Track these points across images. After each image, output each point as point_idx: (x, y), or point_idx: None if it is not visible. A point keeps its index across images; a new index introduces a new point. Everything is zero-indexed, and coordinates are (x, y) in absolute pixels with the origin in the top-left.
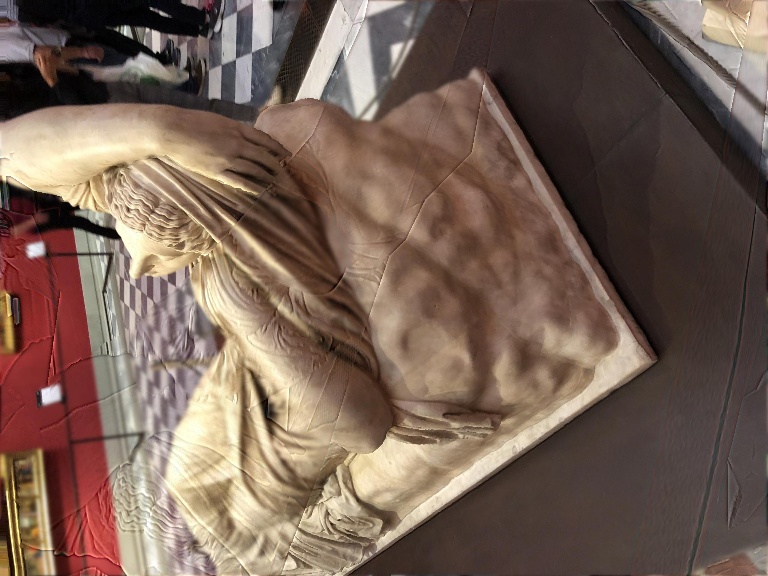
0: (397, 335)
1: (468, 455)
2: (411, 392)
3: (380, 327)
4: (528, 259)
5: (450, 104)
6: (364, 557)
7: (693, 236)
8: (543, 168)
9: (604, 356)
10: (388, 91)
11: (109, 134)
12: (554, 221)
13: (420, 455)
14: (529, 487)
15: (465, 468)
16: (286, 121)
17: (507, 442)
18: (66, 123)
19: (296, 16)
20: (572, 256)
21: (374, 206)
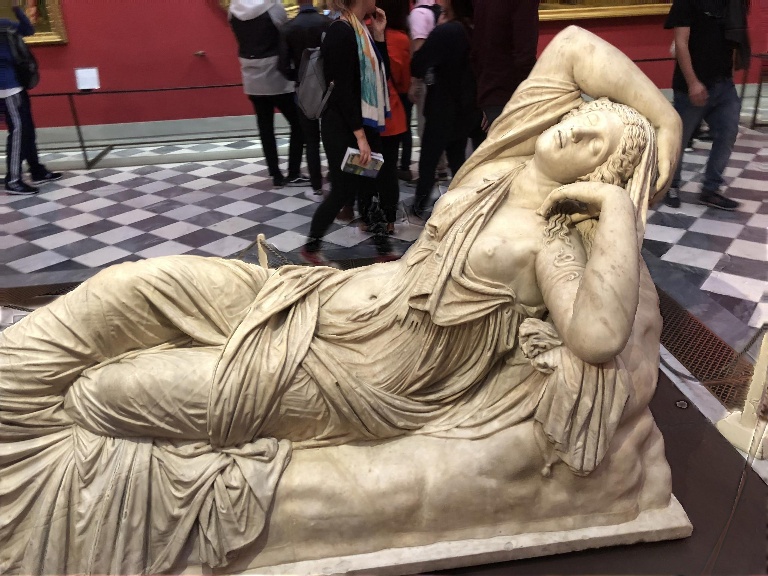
0: None
1: (464, 517)
2: (630, 358)
3: (637, 311)
4: None
5: None
6: None
7: (723, 488)
8: None
9: (656, 506)
10: None
11: (659, 93)
12: None
13: (427, 478)
14: None
15: (422, 541)
16: None
17: (501, 536)
18: None
19: (332, 258)
20: None
21: None
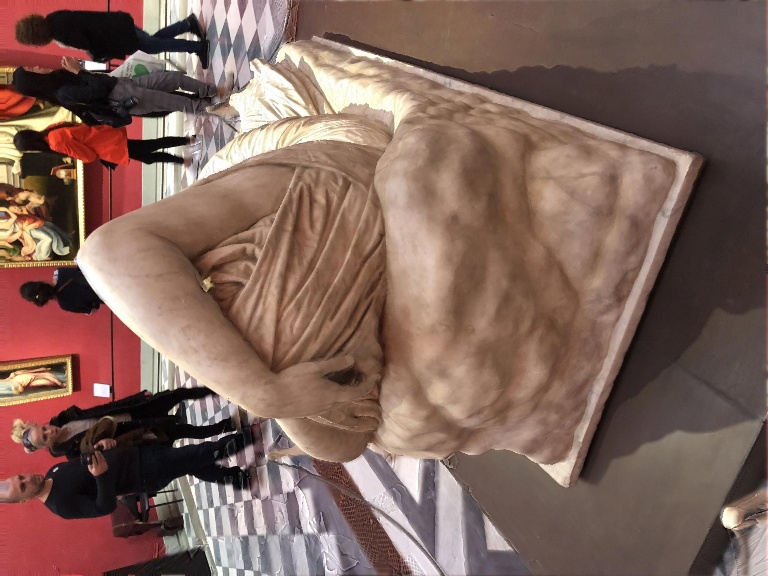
0: (396, 446)
1: None
2: None
3: (388, 433)
4: (544, 409)
5: None
6: None
7: (664, 484)
8: (643, 311)
9: None
10: None
11: None
12: (603, 364)
13: None
14: None
15: None
16: (413, 245)
17: None
18: (169, 347)
19: None
20: (589, 396)
21: None
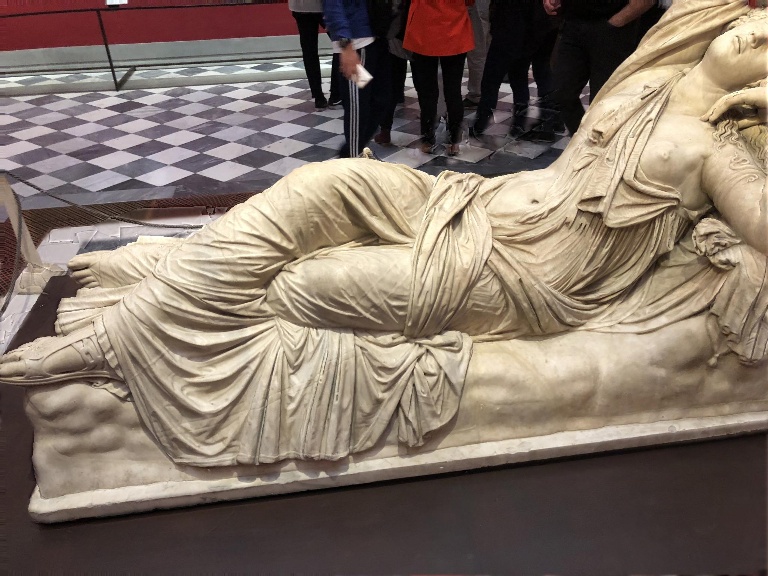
0: None
1: (633, 403)
2: None
3: None
4: None
5: None
6: (302, 475)
7: None
8: None
9: None
10: None
11: None
12: None
13: (600, 368)
14: (655, 473)
15: (592, 425)
16: None
17: (663, 421)
18: None
19: None
20: None
21: None
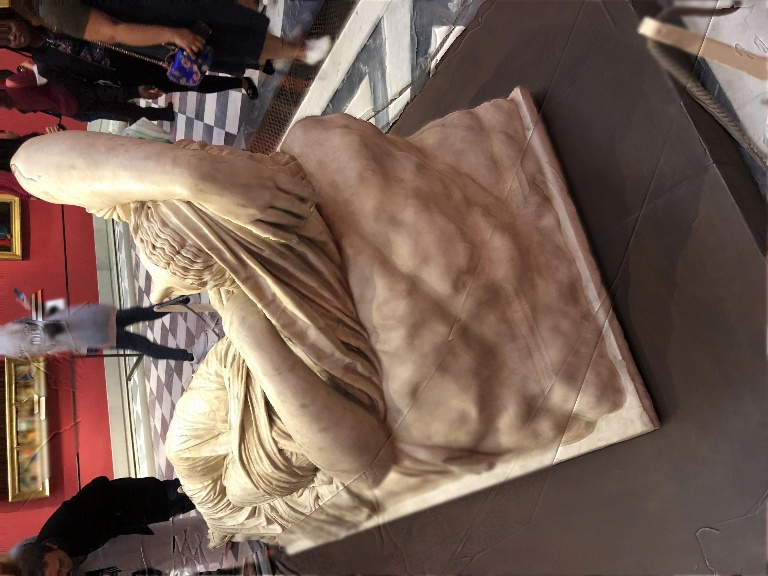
0: (408, 386)
1: None
2: None
3: (392, 375)
4: None
5: (514, 477)
6: None
7: (716, 314)
8: None
9: (608, 414)
10: (453, 450)
11: (141, 176)
12: None
13: None
14: None
15: None
16: (319, 144)
17: None
18: (97, 156)
19: None
20: None
21: (423, 547)
